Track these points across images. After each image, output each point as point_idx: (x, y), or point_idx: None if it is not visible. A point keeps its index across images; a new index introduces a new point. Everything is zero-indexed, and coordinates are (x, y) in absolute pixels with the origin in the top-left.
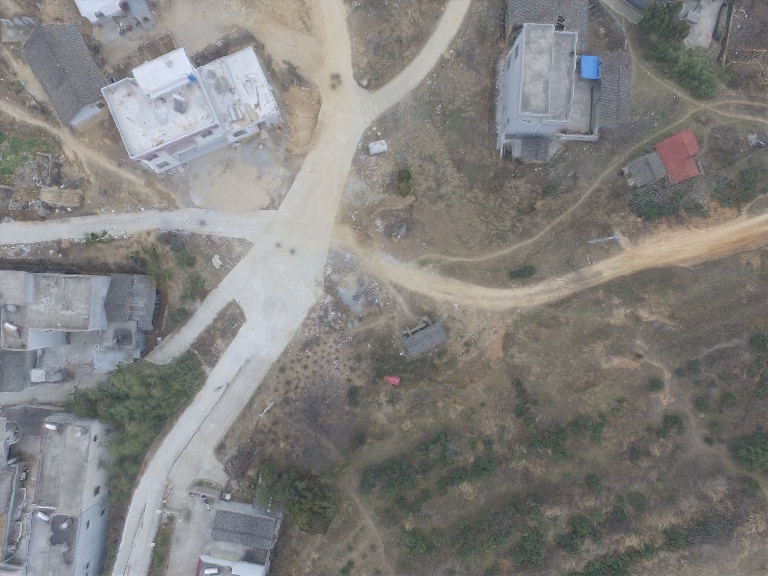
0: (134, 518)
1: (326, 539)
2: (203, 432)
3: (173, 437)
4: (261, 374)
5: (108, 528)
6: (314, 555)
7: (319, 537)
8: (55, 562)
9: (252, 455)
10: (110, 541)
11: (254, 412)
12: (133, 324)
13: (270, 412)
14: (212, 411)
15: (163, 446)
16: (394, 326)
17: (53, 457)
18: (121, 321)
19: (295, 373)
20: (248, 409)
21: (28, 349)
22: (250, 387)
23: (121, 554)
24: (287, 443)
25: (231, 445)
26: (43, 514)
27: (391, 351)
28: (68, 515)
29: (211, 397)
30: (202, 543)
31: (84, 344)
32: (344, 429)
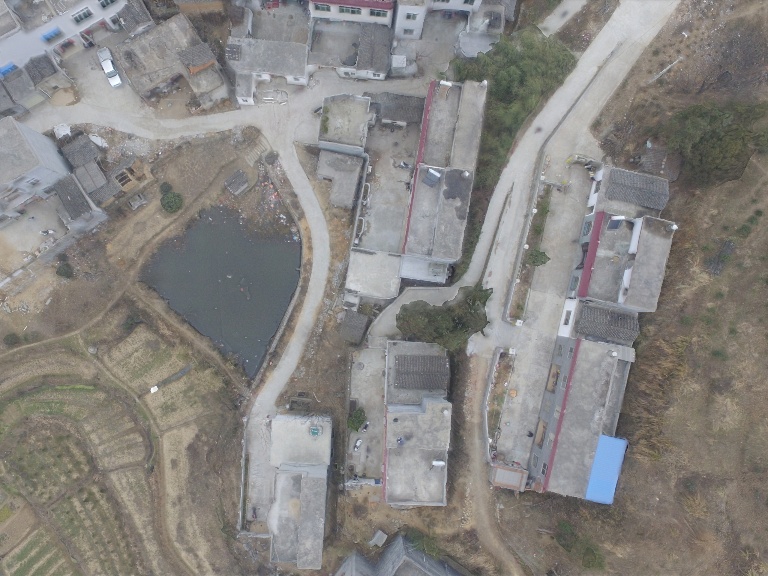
0: (498, 200)
1: (724, 197)
2: (578, 109)
3: (542, 118)
4: (633, 58)
5: (469, 211)
6: (713, 211)
7: (715, 196)
8: (447, 216)
9: (627, 133)
10: (476, 220)
11: (628, 92)
12: (502, 8)
13: (646, 92)
14: (587, 90)
15: (532, 127)
16: (763, 18)
17: (437, 121)
18: (491, 4)
19: (668, 57)
20: (621, 90)
21: (425, 6)
22: (623, 69)
23: (483, 236)
24: (675, 112)
25: (606, 123)
26: (434, 171)
27: (763, 38)
28: (462, 170)
29: (580, 81)
30: (576, 217)
31: (435, 40)
32: (728, 103)
